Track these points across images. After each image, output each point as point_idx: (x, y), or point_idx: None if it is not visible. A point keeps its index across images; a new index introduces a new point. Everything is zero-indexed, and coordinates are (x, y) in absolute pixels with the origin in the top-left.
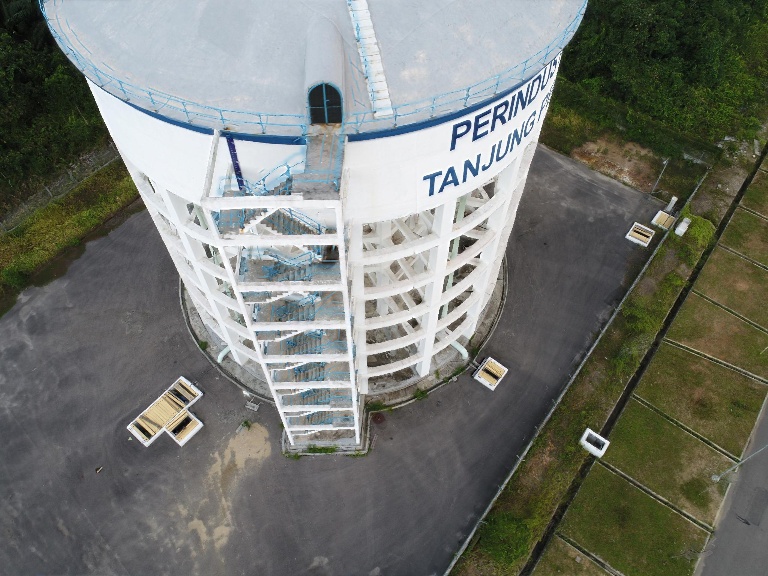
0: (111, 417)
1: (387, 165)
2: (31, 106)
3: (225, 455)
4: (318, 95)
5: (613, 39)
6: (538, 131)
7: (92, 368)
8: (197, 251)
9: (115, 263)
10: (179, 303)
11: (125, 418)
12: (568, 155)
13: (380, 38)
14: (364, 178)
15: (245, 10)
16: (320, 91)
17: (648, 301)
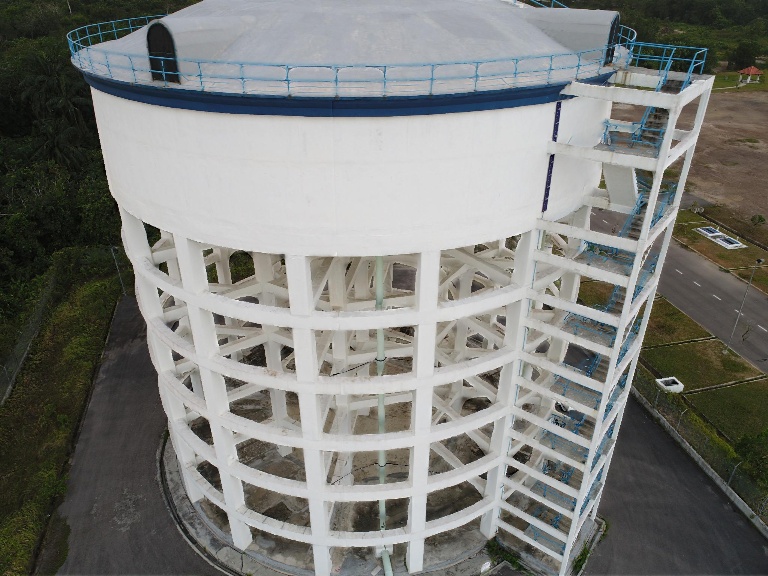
0: None
1: None
2: None
3: None
4: (613, 29)
5: None
6: None
7: None
8: None
9: None
10: None
11: None
12: None
13: None
14: None
15: (467, 15)
16: (615, 24)
17: None
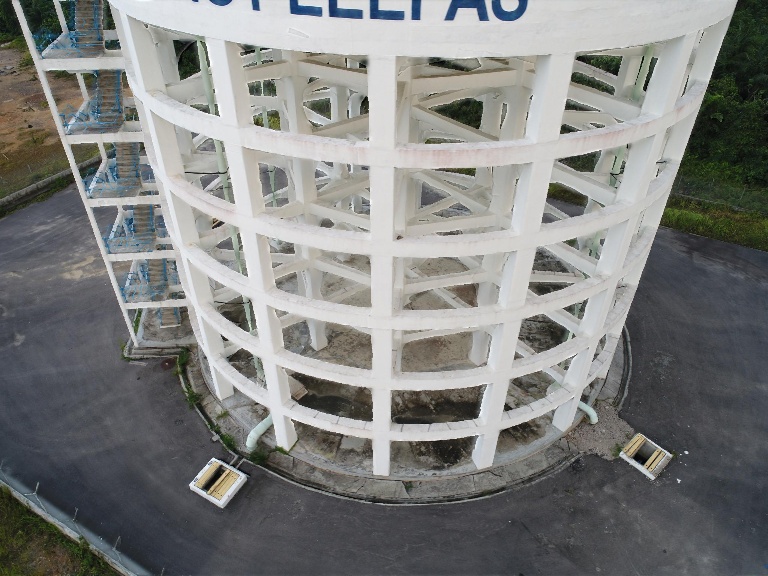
0: None
1: None
2: None
3: None
4: None
5: None
6: None
7: None
8: None
9: None
10: None
11: None
12: None
13: None
14: None
15: None
16: None
17: None
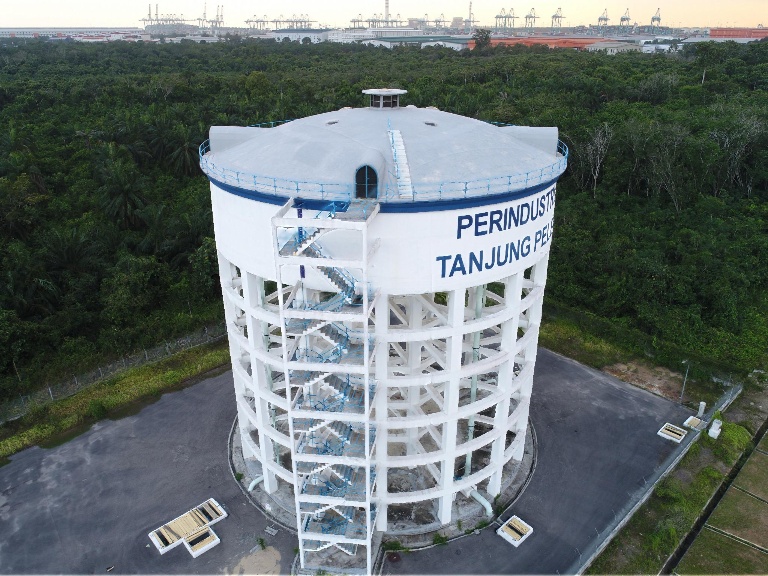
0: (137, 525)
1: (408, 240)
2: (153, 303)
3: (234, 571)
4: (362, 174)
5: (633, 285)
6: (543, 278)
7: (134, 484)
8: (257, 339)
9: (182, 410)
10: (227, 443)
11: (149, 527)
12: (599, 369)
13: (410, 162)
14: (391, 249)
15: (325, 148)
16: (364, 171)
17: (683, 484)
